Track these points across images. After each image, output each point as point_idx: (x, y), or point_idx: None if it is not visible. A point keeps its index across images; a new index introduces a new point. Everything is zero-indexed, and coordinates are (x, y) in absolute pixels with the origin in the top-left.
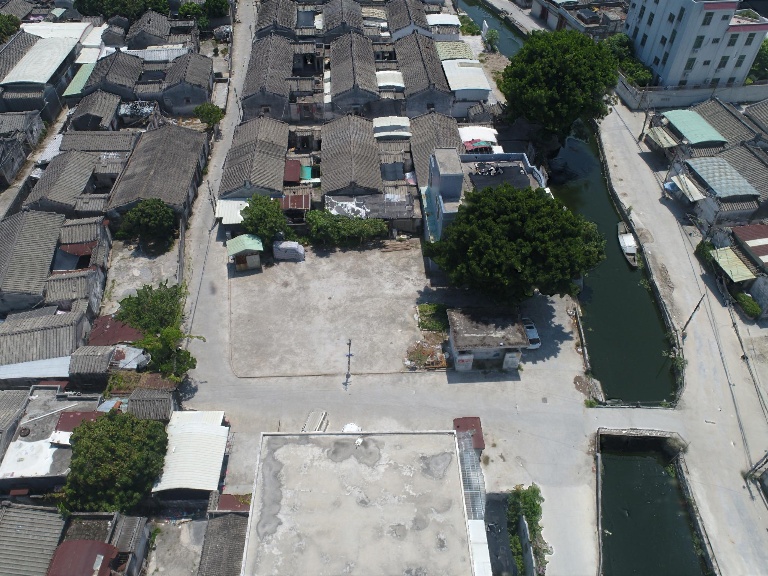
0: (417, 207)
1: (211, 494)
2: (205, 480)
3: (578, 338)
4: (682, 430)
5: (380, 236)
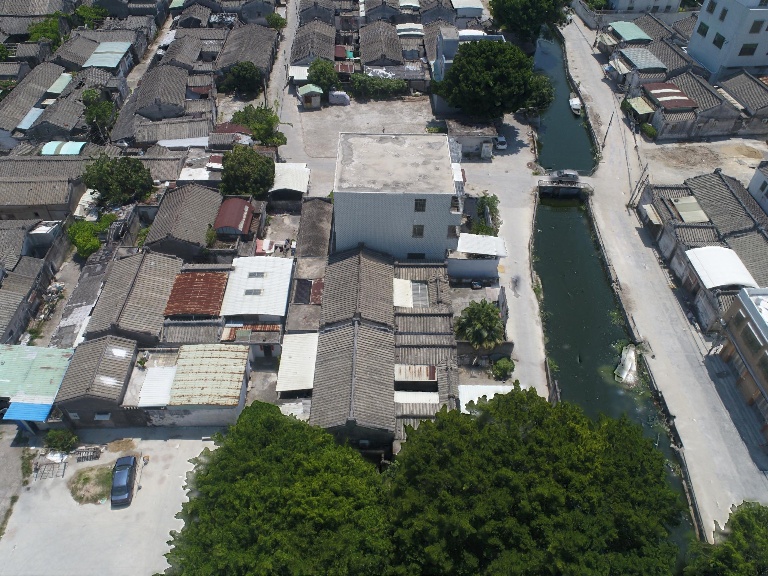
0: (427, 74)
1: (303, 195)
2: (299, 188)
3: (533, 146)
4: (592, 186)
5: (401, 93)
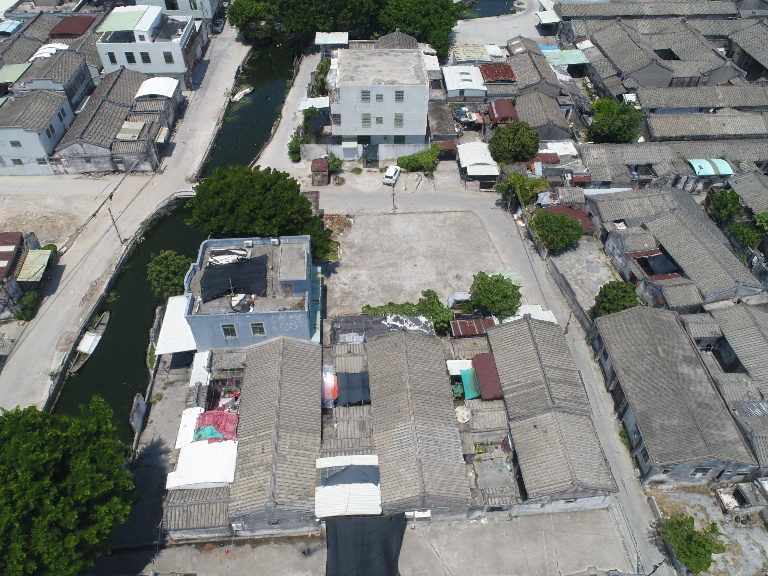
0: (327, 333)
1: None
2: None
3: None
4: (181, 187)
5: None
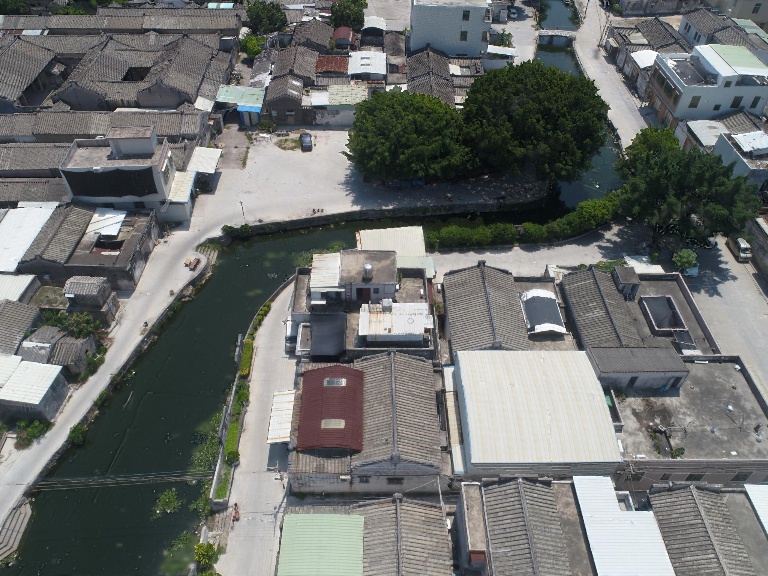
0: None
1: None
2: (381, 27)
3: None
4: None
5: None
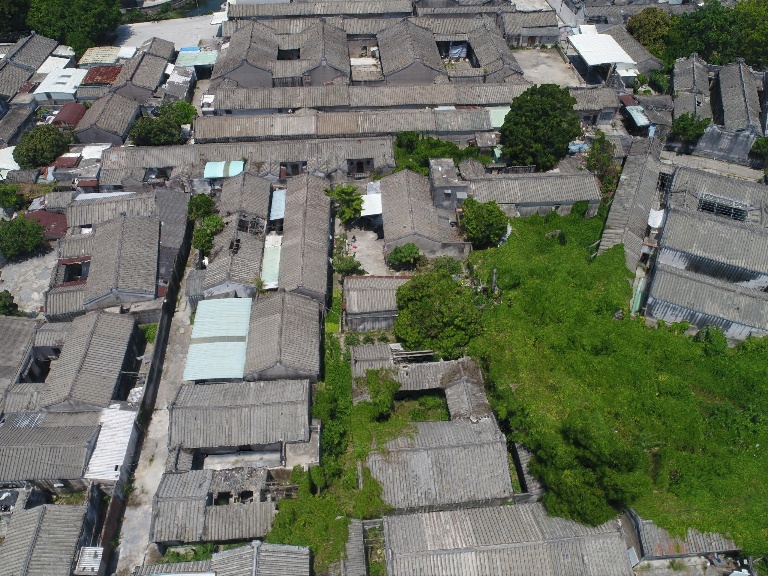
0: None
1: None
2: (2, 151)
3: None
4: None
5: None
